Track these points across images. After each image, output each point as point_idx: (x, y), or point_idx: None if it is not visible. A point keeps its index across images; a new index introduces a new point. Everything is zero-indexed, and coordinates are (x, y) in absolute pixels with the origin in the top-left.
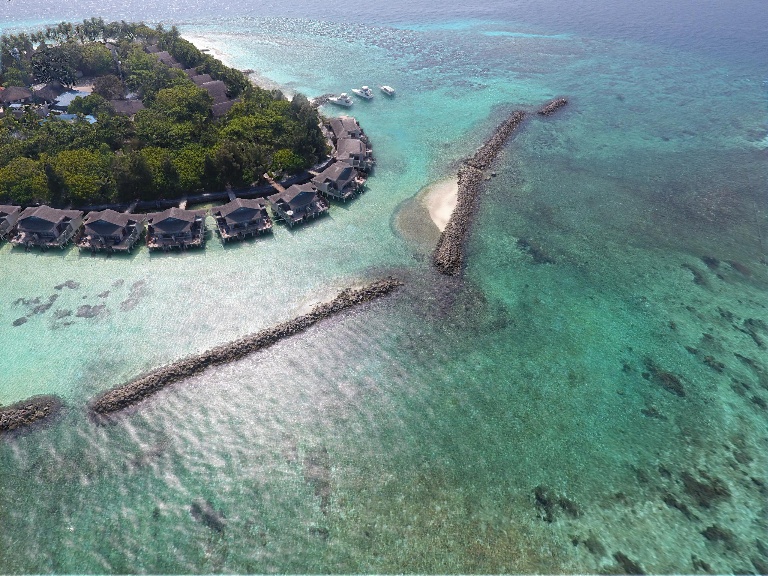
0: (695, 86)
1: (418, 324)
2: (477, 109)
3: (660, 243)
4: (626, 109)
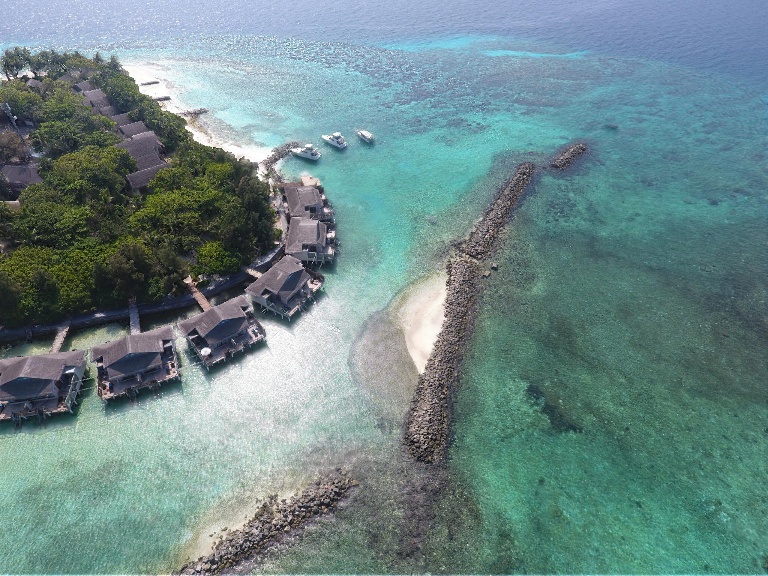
0: (739, 121)
1: (374, 573)
2: (475, 160)
3: (728, 387)
4: (659, 157)
